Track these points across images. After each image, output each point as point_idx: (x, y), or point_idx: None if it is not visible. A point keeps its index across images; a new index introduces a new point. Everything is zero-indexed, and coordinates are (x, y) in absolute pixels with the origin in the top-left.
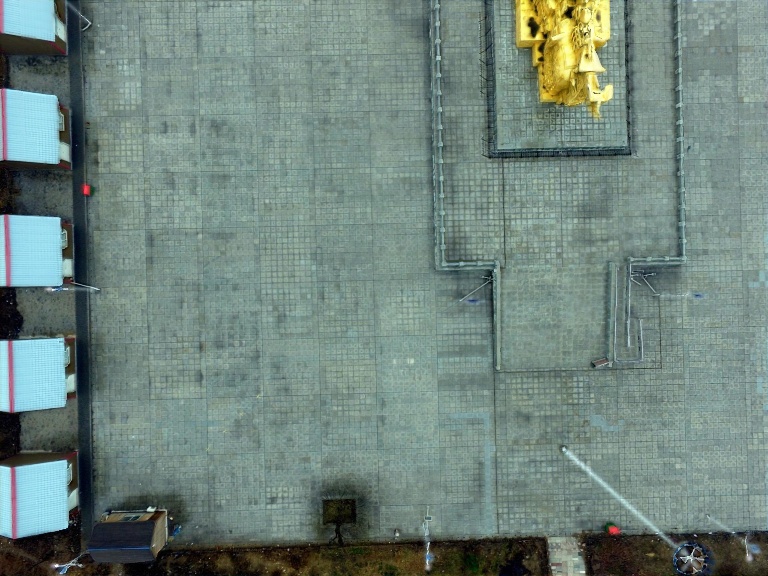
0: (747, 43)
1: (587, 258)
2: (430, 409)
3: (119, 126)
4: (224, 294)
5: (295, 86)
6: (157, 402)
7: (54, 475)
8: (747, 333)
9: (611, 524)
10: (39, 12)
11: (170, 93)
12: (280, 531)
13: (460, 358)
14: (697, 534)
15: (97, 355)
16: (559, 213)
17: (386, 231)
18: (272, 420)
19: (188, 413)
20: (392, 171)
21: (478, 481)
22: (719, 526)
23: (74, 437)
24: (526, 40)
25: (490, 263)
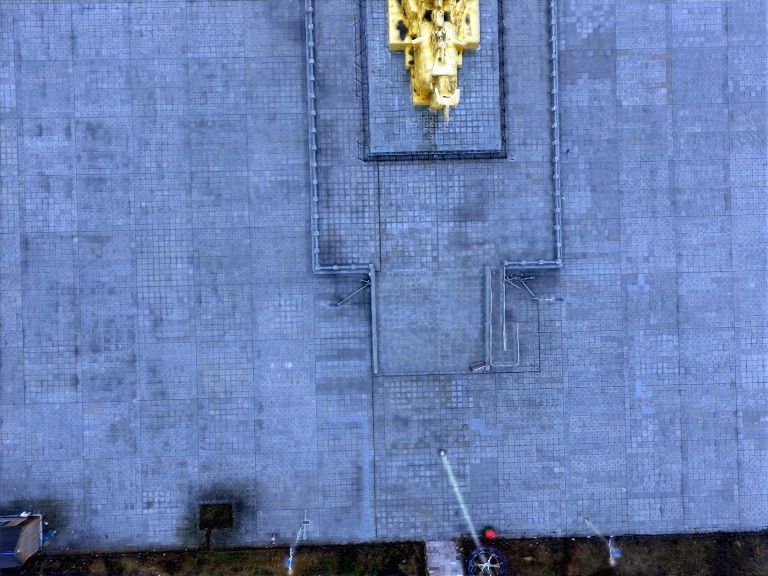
0: (626, 46)
1: (463, 262)
2: (308, 413)
3: None
4: (100, 298)
5: (171, 89)
6: (32, 406)
7: None
8: (626, 337)
9: (489, 528)
10: None
11: (45, 96)
12: (156, 536)
13: (338, 362)
14: (575, 538)
15: None
16: (435, 216)
17: (264, 234)
18: (149, 424)
19: (63, 417)
20: (269, 174)
21: (356, 485)
22: (598, 530)
23: None
24: (395, 43)
25: (364, 267)
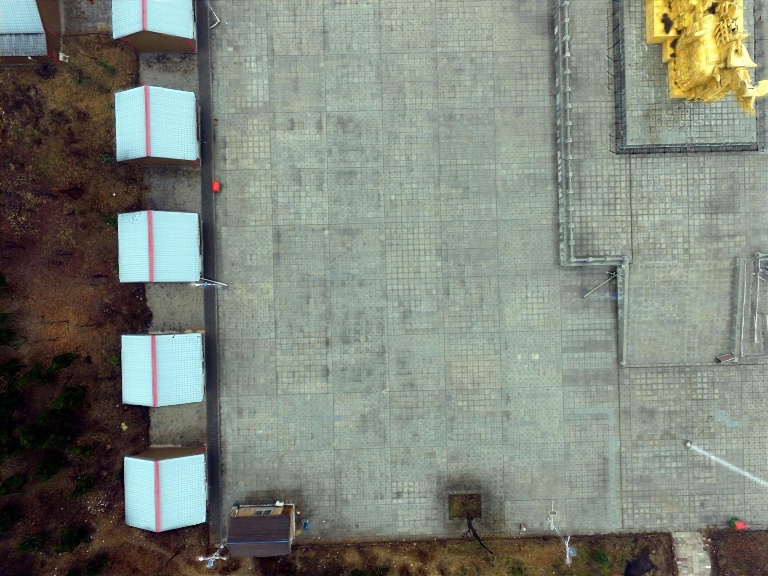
0: None
1: (714, 254)
2: (555, 404)
3: (247, 123)
4: (350, 290)
5: (421, 83)
6: (284, 397)
7: (193, 469)
8: None
9: (736, 519)
10: (178, 9)
11: (297, 90)
12: (406, 526)
13: (584, 353)
14: None
15: (225, 350)
16: (686, 209)
17: (511, 227)
18: (398, 415)
19: (315, 408)
20: (517, 167)
21: (603, 476)
22: None
23: (203, 432)
24: (659, 36)
25: (618, 259)
